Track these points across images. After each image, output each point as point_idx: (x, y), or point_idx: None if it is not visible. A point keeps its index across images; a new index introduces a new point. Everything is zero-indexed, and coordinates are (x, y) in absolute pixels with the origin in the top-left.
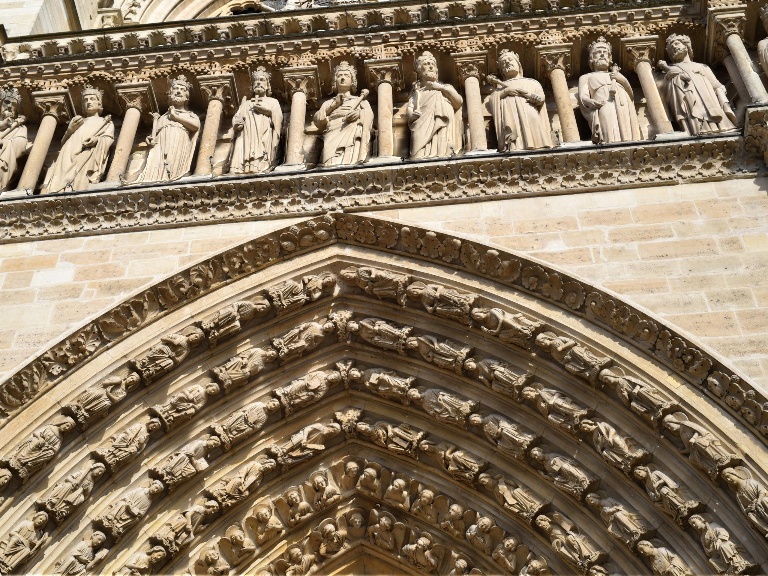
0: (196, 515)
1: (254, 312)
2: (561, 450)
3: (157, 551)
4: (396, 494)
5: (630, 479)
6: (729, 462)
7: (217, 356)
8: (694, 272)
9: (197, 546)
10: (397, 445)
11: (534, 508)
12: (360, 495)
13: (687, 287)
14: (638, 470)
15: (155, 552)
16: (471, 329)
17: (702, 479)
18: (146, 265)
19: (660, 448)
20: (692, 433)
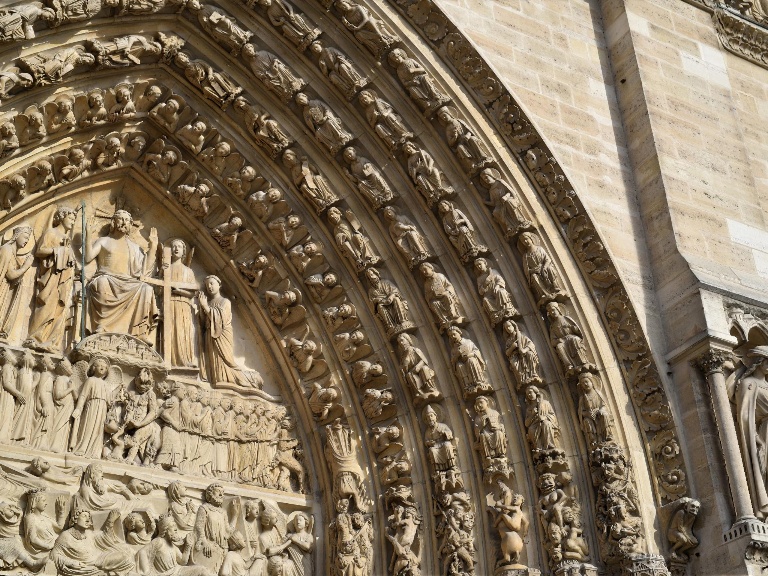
0: (10, 82)
1: None
2: (372, 158)
3: None
4: (193, 135)
5: (429, 207)
6: (529, 227)
7: None
8: (533, 52)
9: None
10: (213, 90)
11: (331, 199)
12: (148, 120)
13: (527, 63)
14: (445, 203)
15: None
16: (328, 13)
17: (494, 231)
18: None
19: (466, 192)
20: (505, 191)
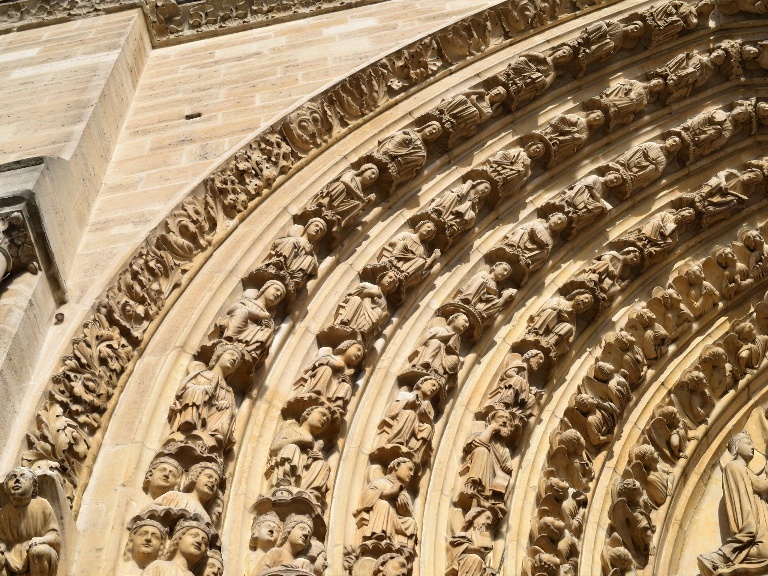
0: (614, 261)
1: (623, 37)
2: None
3: (581, 293)
4: None
5: None
6: None
7: (587, 88)
8: None
9: (619, 311)
10: None
11: None
12: None
13: None
14: None
15: (579, 295)
16: None
17: None
18: (470, 0)
19: None
20: None
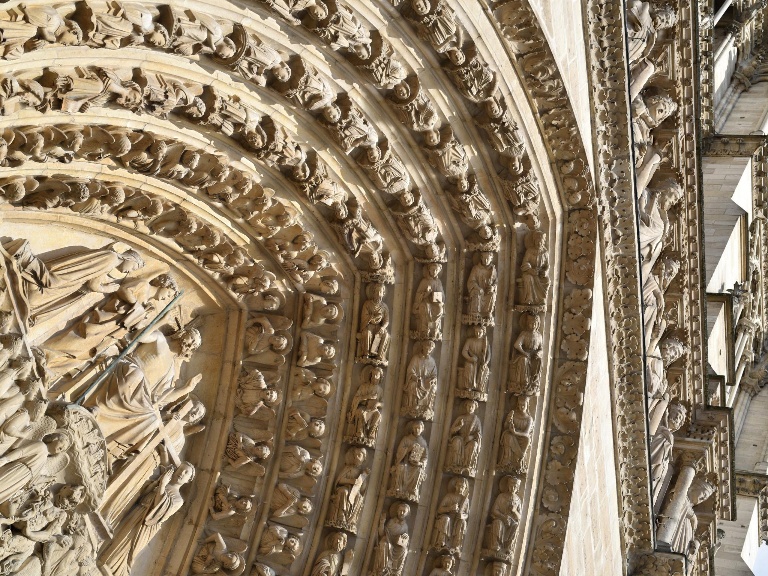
0: (296, 160)
1: (509, 156)
2: (411, 532)
3: (263, 139)
4: (318, 350)
5: None
6: None
7: None
8: None
9: (252, 161)
10: (372, 340)
11: (353, 527)
12: (297, 296)
13: None
14: None
15: (262, 137)
16: (504, 394)
17: None
18: None
19: None
20: None
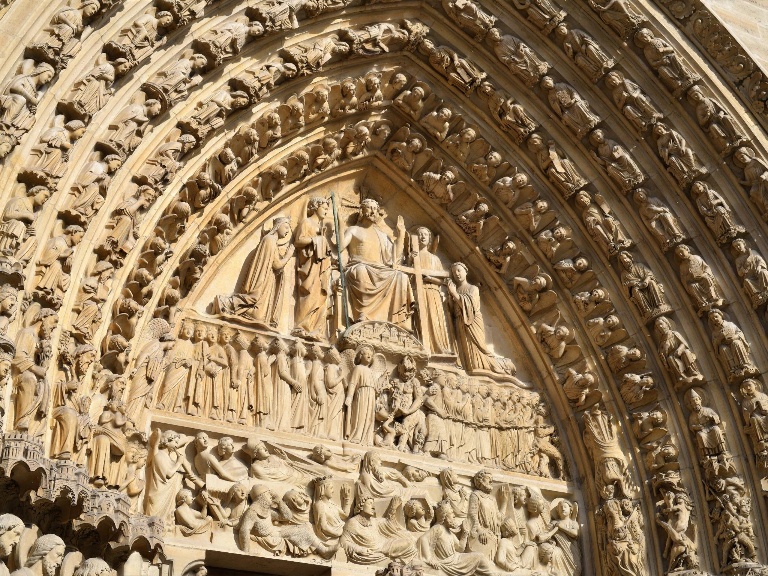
0: (277, 73)
1: None
2: (619, 140)
3: (243, 96)
4: (439, 122)
5: (681, 188)
6: None
7: None
8: None
9: (260, 104)
10: (459, 76)
11: (581, 183)
12: (392, 108)
13: None
14: (699, 184)
15: (241, 97)
16: None
17: (750, 211)
18: None
19: (719, 172)
20: (762, 170)
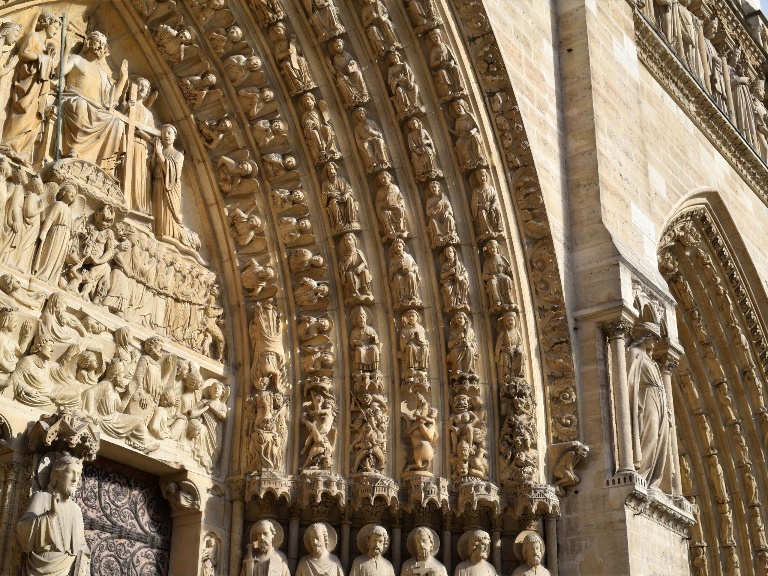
0: None
1: None
2: (355, 55)
3: None
4: None
5: (398, 119)
6: None
7: None
8: None
9: None
10: None
11: (311, 84)
12: None
13: None
14: (416, 121)
15: None
16: None
17: (451, 159)
18: None
19: (435, 115)
20: (472, 126)
